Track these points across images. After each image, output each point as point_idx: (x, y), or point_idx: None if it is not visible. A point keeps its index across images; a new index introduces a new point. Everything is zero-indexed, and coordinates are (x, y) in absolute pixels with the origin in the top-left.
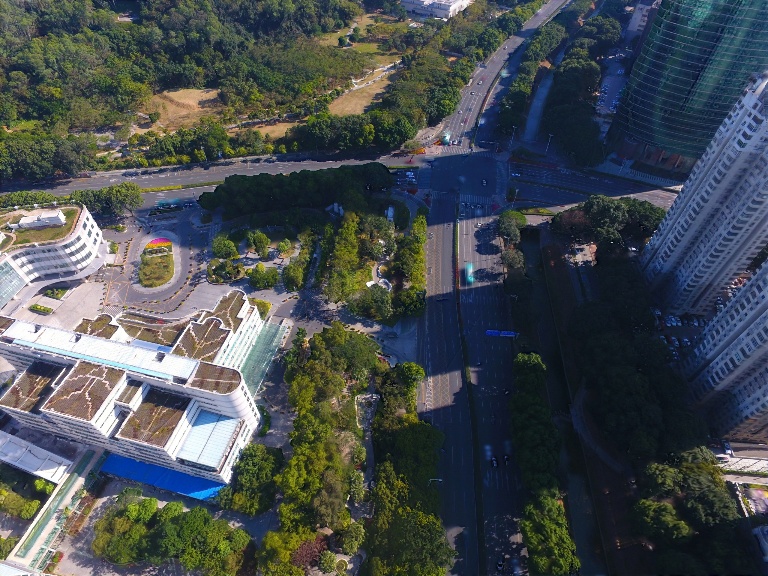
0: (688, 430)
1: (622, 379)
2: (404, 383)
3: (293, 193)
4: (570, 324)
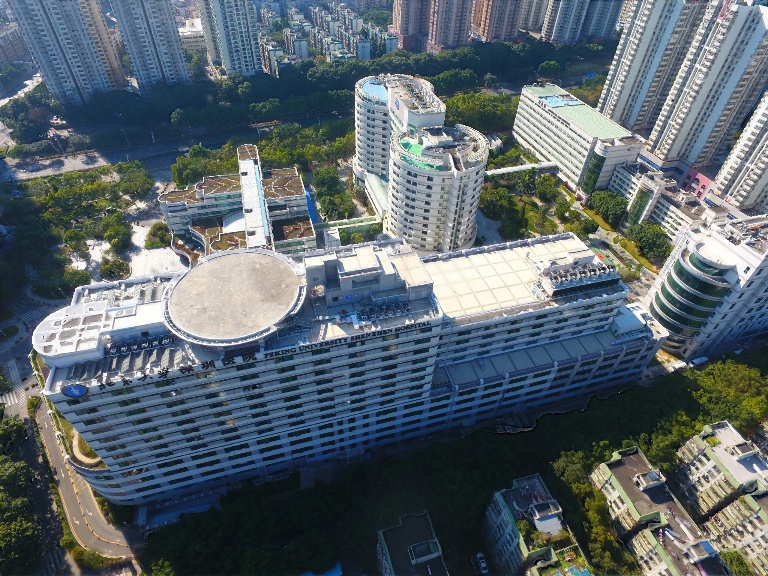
0: (204, 80)
1: (183, 88)
2: (205, 154)
3: None
4: (141, 116)
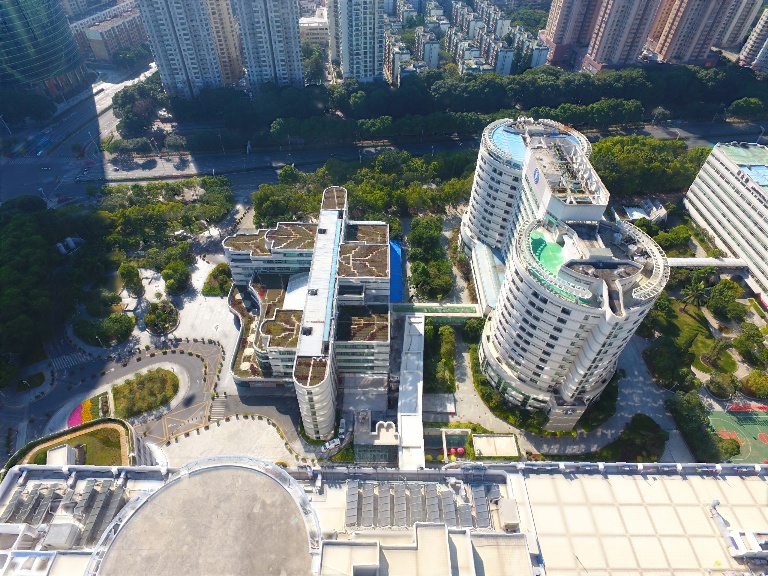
0: None
1: (291, 93)
2: (295, 178)
3: (43, 257)
4: (243, 120)
